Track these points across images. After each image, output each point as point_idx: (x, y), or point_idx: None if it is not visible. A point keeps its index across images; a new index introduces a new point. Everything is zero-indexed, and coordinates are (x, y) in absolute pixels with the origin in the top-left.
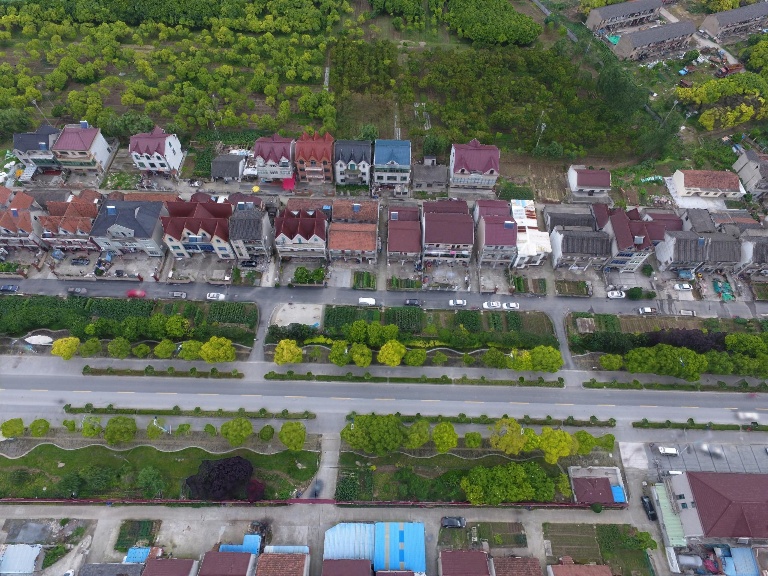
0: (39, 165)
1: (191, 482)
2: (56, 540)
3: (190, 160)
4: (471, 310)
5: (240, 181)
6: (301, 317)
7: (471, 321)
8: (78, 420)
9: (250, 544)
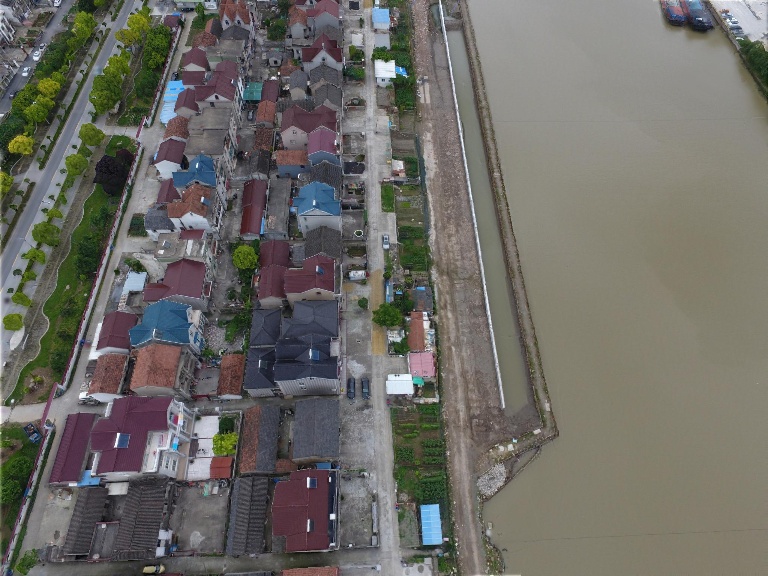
0: None
1: (107, 187)
2: None
3: None
4: None
5: None
6: None
7: None
8: (29, 290)
9: None
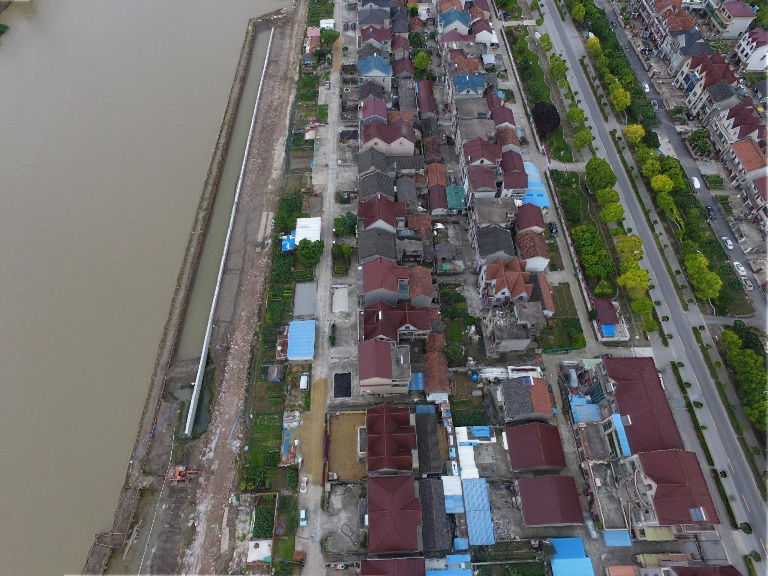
0: (706, 8)
1: None
2: (497, 70)
3: (762, 75)
4: None
5: (761, 102)
6: (662, 148)
7: (714, 249)
8: None
9: (517, 132)
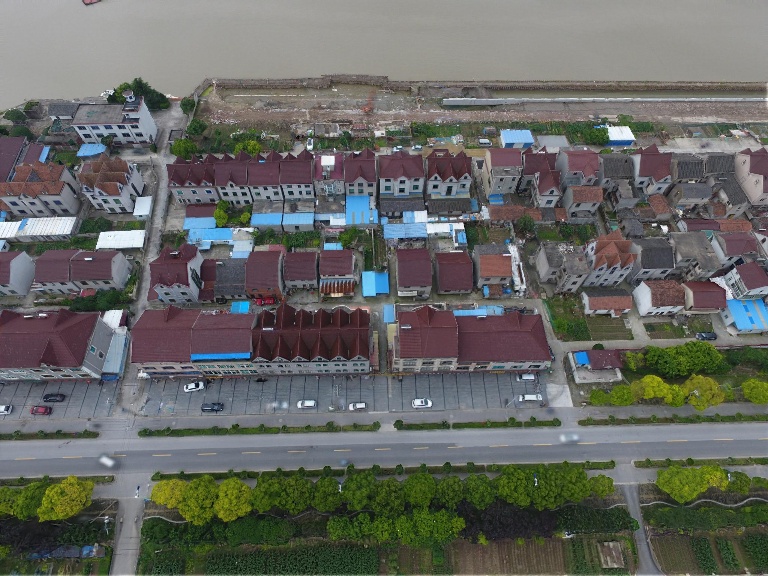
0: None
1: None
2: None
3: None
4: (763, 574)
5: None
6: None
7: (762, 551)
8: None
9: None
